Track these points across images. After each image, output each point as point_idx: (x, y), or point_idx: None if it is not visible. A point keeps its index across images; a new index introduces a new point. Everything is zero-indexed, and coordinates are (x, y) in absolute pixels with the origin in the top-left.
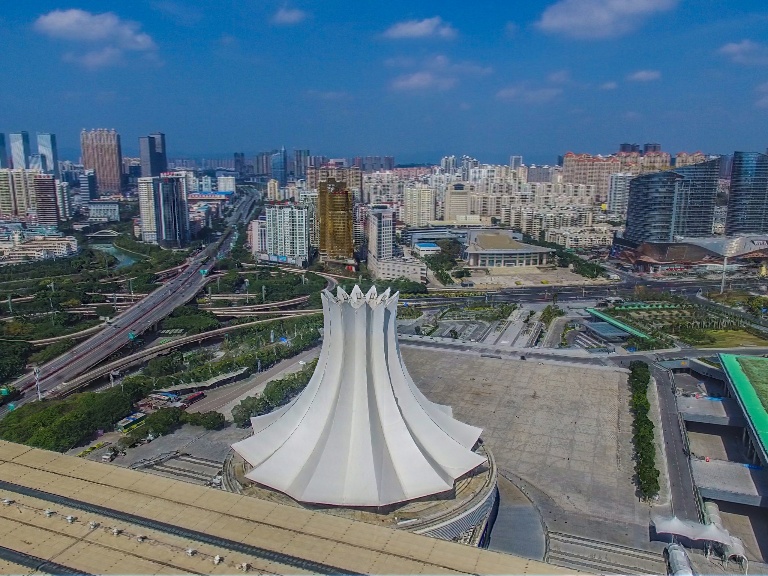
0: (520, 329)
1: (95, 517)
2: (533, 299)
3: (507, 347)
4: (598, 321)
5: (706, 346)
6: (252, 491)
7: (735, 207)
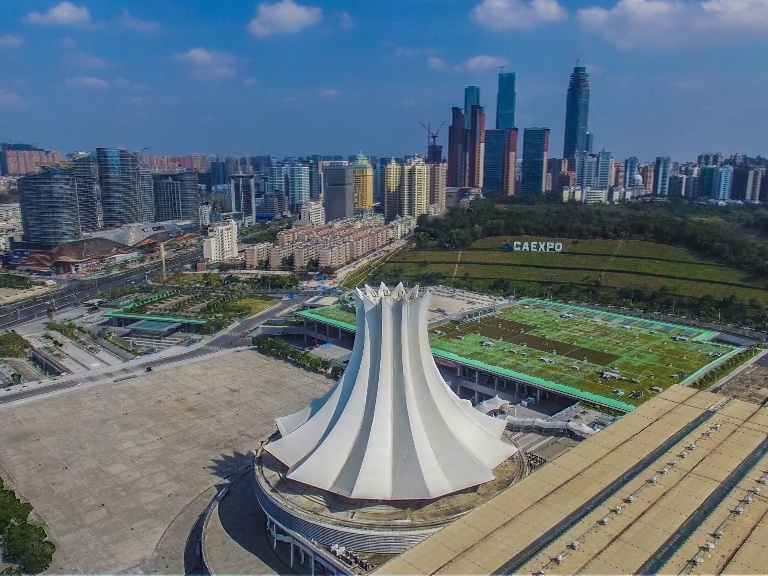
0: (81, 349)
1: (519, 575)
2: (6, 323)
3: (108, 368)
4: (124, 323)
5: (249, 315)
6: (419, 516)
7: (110, 200)
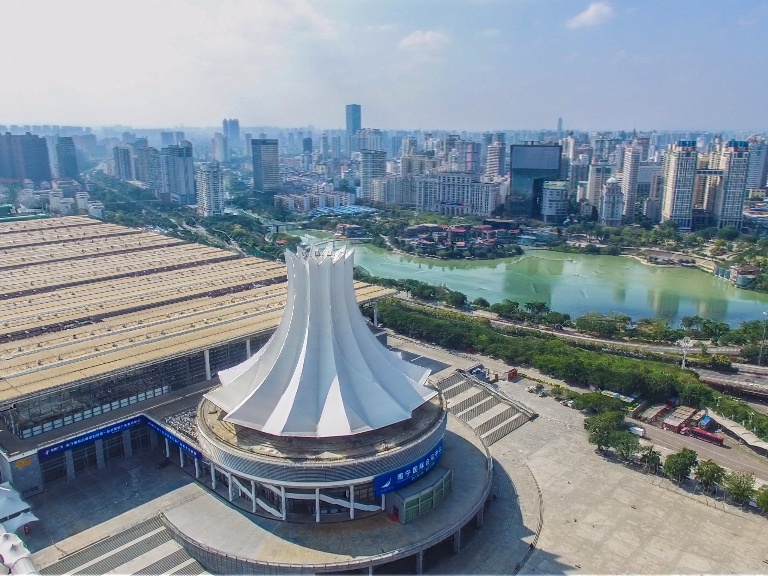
0: None
1: None
2: None
3: None
4: None
5: None
6: None
7: None
